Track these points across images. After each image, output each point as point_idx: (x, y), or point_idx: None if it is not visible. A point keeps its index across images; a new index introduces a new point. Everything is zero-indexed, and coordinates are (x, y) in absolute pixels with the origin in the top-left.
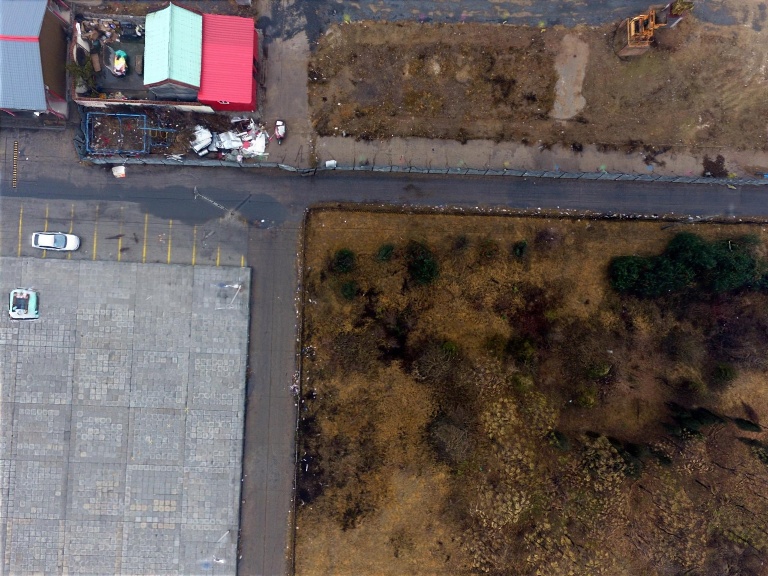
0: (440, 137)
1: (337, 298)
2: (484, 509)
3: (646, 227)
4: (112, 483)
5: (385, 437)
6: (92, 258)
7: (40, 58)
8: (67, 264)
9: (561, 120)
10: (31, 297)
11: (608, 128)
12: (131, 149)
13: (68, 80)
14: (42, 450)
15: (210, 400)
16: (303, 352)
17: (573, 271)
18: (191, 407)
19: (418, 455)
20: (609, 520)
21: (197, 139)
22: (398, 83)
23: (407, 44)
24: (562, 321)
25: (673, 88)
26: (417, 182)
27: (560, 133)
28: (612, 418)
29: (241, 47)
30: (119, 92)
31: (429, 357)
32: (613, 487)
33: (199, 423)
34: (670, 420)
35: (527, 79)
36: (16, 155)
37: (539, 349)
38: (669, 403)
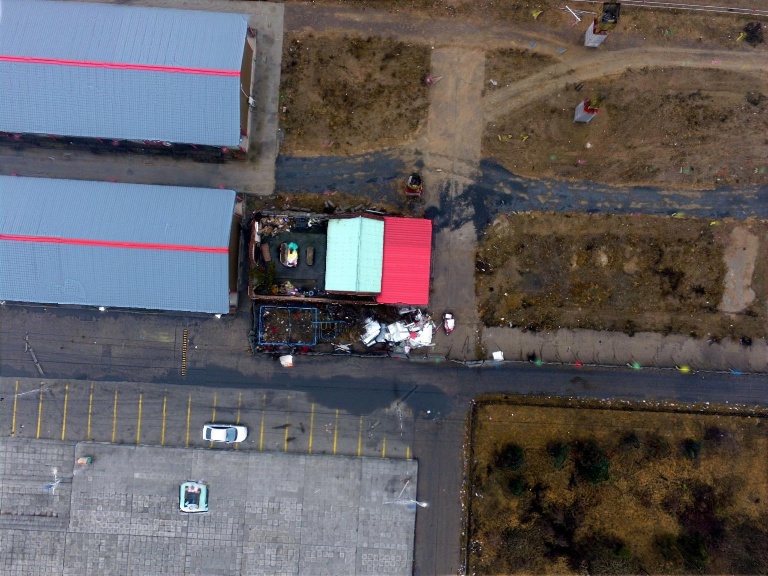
0: (607, 329)
1: (504, 493)
2: None
3: None
4: None
5: None
6: (259, 448)
7: (228, 267)
8: (236, 456)
9: (730, 313)
10: (202, 491)
11: None
12: (299, 338)
13: (239, 270)
14: None
15: None
16: (469, 547)
17: (743, 469)
18: None
19: None
20: None
21: (367, 332)
22: (565, 274)
23: (575, 235)
24: (732, 520)
25: None
26: (584, 374)
27: (729, 326)
28: None
29: (419, 249)
30: (288, 281)
31: (603, 562)
32: None
33: None
34: None
35: (696, 271)
36: (185, 343)
37: (708, 548)
38: None
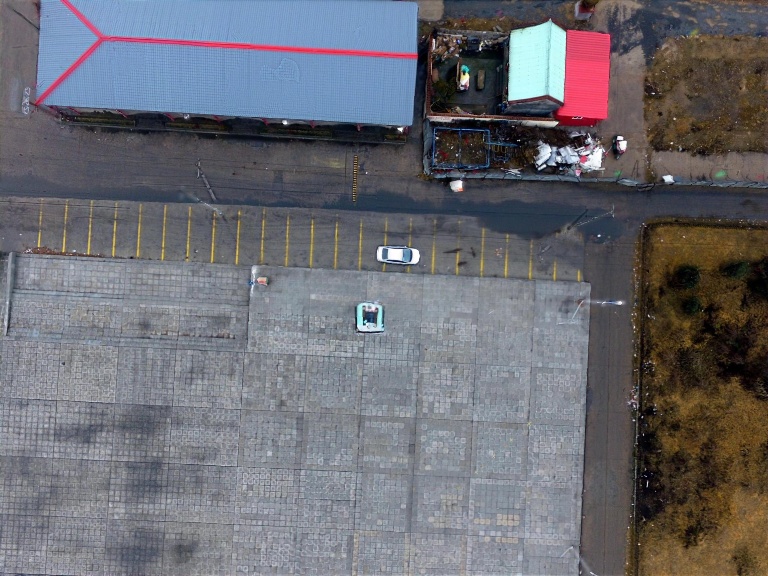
0: None
1: (676, 314)
2: None
3: None
4: (456, 496)
5: (727, 454)
6: (431, 272)
7: (415, 74)
8: (411, 278)
9: None
10: (379, 311)
11: None
12: (469, 163)
13: None
14: (387, 463)
15: (552, 415)
16: (642, 368)
17: None
18: (533, 422)
19: (760, 473)
20: None
21: (540, 154)
22: (734, 98)
23: (744, 59)
24: None
25: None
26: (754, 197)
27: None
28: None
29: (598, 63)
30: (457, 107)
31: None
32: None
33: (541, 438)
34: None
35: None
36: (356, 169)
37: None
38: None
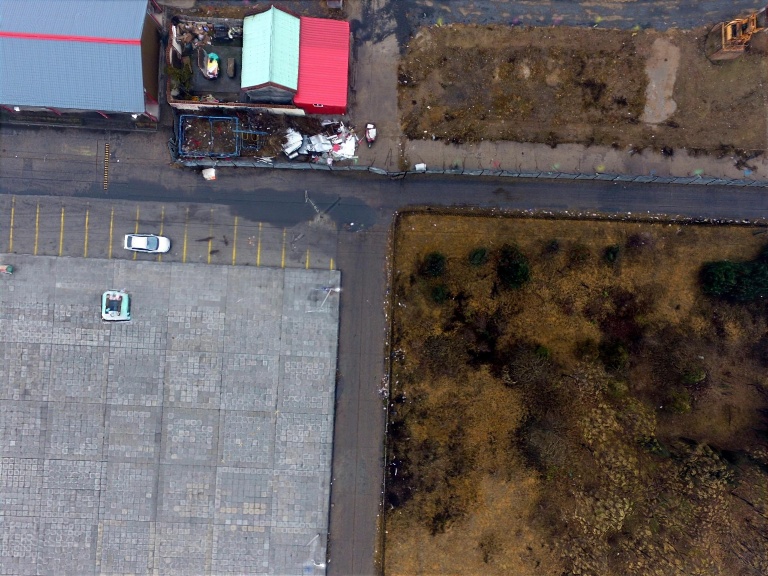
0: (530, 141)
1: (427, 302)
2: (585, 515)
3: (738, 232)
4: (202, 485)
5: (475, 442)
6: (182, 260)
7: (141, 61)
8: (159, 266)
9: (651, 124)
10: (124, 299)
11: (699, 132)
12: (221, 151)
13: (160, 82)
14: (133, 452)
15: (300, 403)
16: (392, 356)
17: (664, 276)
18: (281, 410)
19: (508, 460)
20: (714, 528)
21: (289, 142)
22: (488, 86)
23: (497, 47)
24: (653, 326)
25: (765, 92)
26: (506, 186)
27: (650, 137)
28: (703, 424)
29: (337, 50)
30: (210, 95)
31: (522, 362)
32: (717, 495)
33: (289, 426)
34: (763, 427)
35: (617, 83)
36: (107, 157)
37: (629, 354)
38: (763, 410)
